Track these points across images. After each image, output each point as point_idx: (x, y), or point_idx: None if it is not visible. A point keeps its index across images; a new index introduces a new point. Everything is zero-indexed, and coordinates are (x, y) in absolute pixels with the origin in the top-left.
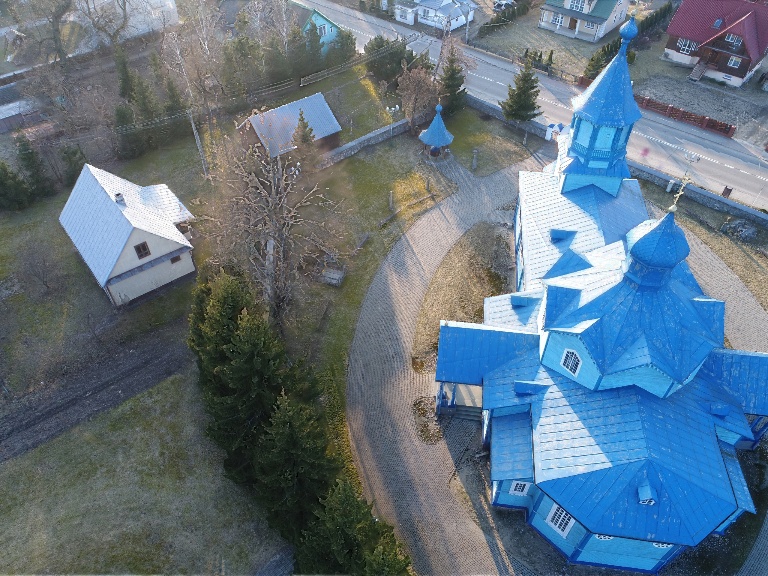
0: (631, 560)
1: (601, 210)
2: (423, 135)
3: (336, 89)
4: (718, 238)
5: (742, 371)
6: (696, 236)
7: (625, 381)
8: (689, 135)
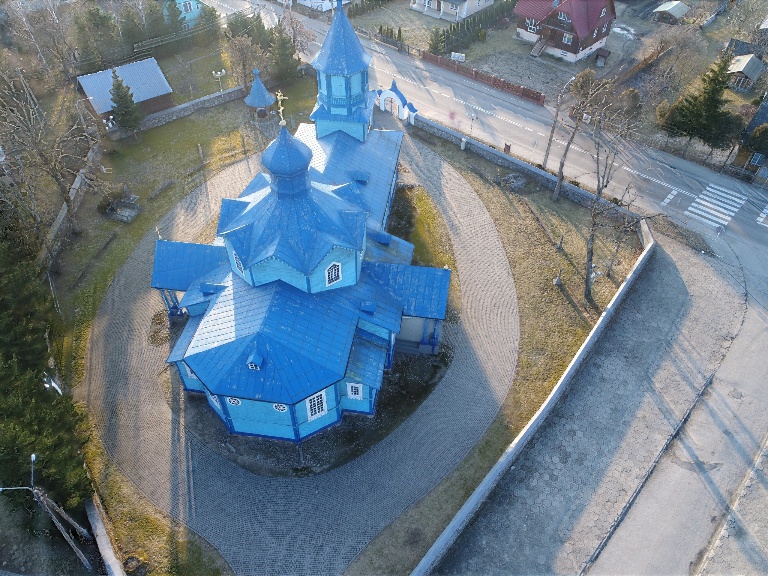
0: (273, 428)
1: (336, 150)
2: (247, 97)
3: (179, 57)
4: (490, 188)
5: (405, 279)
6: (471, 186)
7: (271, 276)
8: (505, 103)
